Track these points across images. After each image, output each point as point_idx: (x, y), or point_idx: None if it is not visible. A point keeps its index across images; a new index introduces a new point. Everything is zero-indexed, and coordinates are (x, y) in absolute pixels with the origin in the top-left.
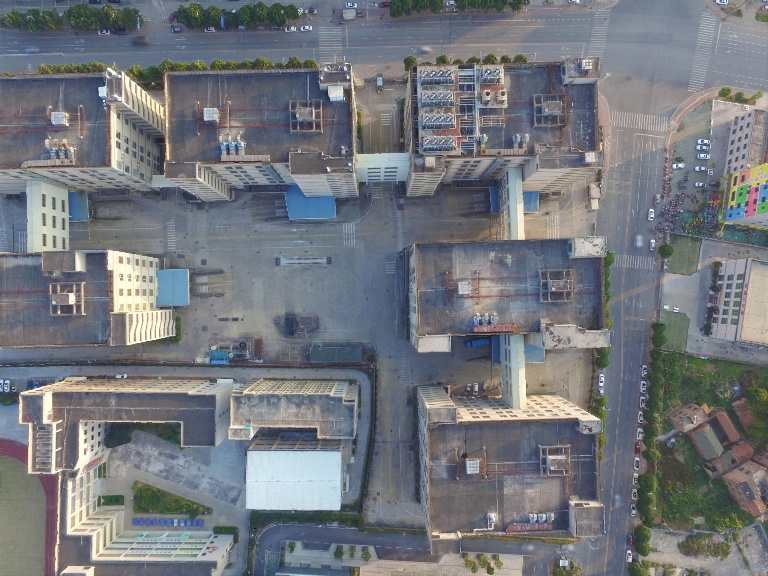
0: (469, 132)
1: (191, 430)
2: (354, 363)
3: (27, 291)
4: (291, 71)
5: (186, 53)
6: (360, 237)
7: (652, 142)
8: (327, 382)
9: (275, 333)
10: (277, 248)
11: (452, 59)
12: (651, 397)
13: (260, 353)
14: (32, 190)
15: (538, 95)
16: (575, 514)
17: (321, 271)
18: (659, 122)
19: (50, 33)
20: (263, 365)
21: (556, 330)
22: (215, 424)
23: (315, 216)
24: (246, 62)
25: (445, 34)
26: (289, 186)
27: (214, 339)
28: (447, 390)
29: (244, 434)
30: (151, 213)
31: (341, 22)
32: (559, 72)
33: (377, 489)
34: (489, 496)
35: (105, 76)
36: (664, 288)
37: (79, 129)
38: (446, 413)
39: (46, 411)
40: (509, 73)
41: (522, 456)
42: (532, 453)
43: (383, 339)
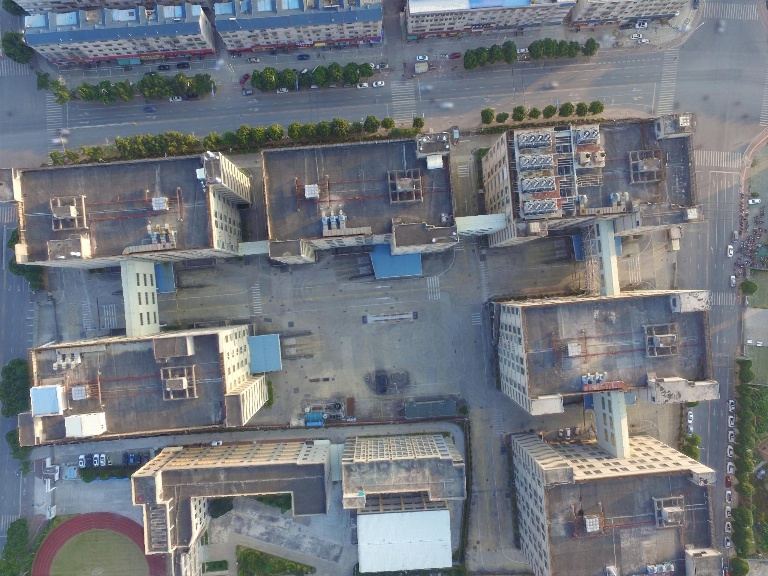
0: (567, 192)
1: (301, 499)
2: (447, 416)
3: (137, 377)
4: (387, 141)
5: (259, 115)
6: (445, 290)
7: (727, 179)
8: (423, 437)
9: (366, 391)
10: (363, 306)
11: (525, 107)
12: (742, 432)
13: (353, 412)
14: (127, 271)
15: (634, 152)
16: (694, 564)
17: (408, 326)
18: (733, 158)
19: (120, 102)
20: (358, 424)
21: (666, 385)
22: (325, 492)
23: (401, 274)
24: (325, 124)
25: (517, 82)
26: (374, 246)
27: (306, 401)
28: (541, 438)
29: (358, 502)
30: (235, 279)
31: (413, 76)
32: (652, 127)
33: (476, 538)
34: (607, 550)
35: (203, 158)
36: (746, 323)
37: (179, 212)
38: (563, 473)
39: (158, 491)
40: (603, 131)
41: (637, 509)
42: (646, 506)
43: (474, 390)
